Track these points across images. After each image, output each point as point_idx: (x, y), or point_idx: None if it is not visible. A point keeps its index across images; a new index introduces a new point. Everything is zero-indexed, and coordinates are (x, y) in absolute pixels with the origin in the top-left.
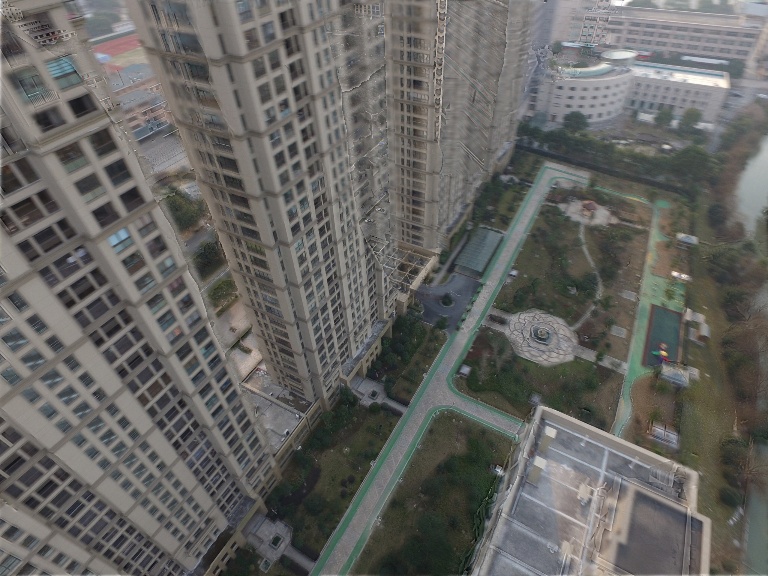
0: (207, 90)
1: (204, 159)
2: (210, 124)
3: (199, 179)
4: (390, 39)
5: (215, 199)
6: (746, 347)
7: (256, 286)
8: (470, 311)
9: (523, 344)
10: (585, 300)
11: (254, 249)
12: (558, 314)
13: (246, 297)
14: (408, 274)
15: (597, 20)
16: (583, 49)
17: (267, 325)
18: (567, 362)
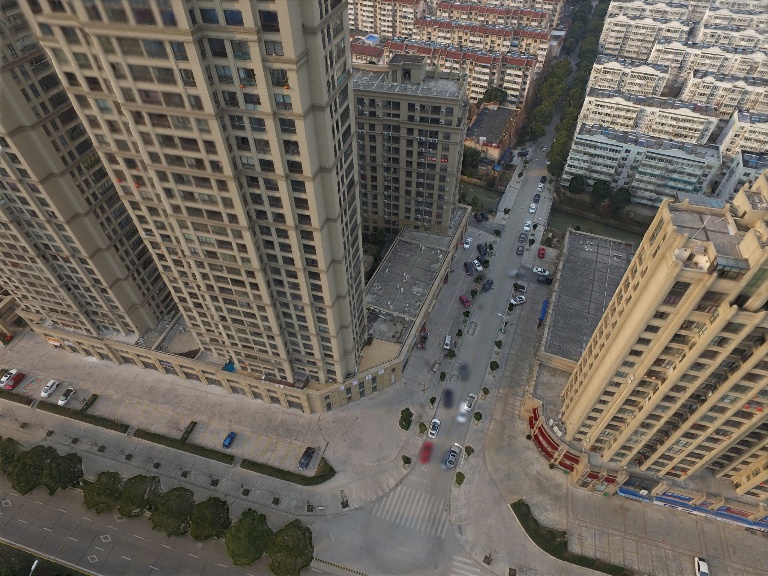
0: (15, 12)
1: (27, 96)
2: (25, 48)
3: (19, 136)
4: None
5: (46, 139)
6: None
7: (106, 209)
8: None
9: None
10: None
11: (91, 164)
12: None
13: (103, 238)
14: None
15: None
16: None
17: (127, 250)
18: None
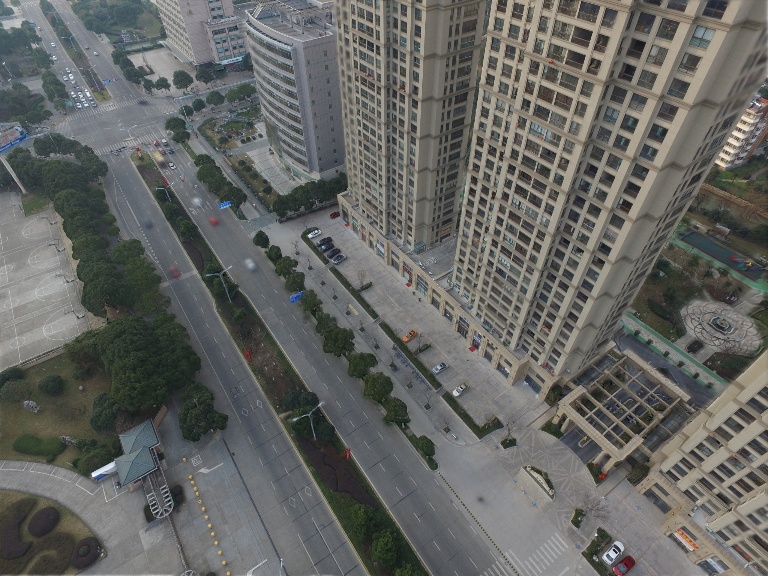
0: None
1: None
2: None
3: None
4: (680, 139)
5: None
6: (741, 223)
7: None
8: (685, 364)
9: (735, 345)
10: (693, 273)
11: None
12: (691, 300)
13: None
14: (654, 392)
15: (226, 32)
16: (227, 67)
17: None
18: (767, 326)
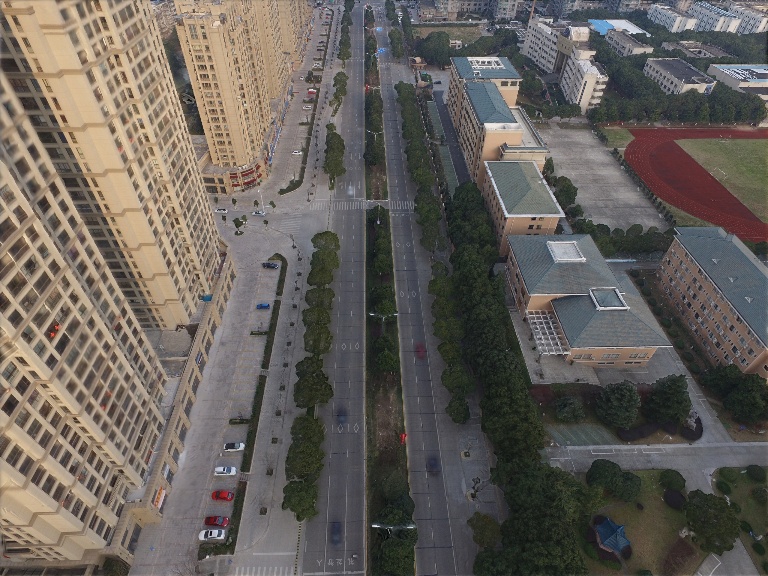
0: None
1: None
2: None
3: None
4: None
5: None
6: None
7: None
8: None
9: None
10: None
11: None
12: None
13: None
14: None
15: None
16: None
17: None
18: None
